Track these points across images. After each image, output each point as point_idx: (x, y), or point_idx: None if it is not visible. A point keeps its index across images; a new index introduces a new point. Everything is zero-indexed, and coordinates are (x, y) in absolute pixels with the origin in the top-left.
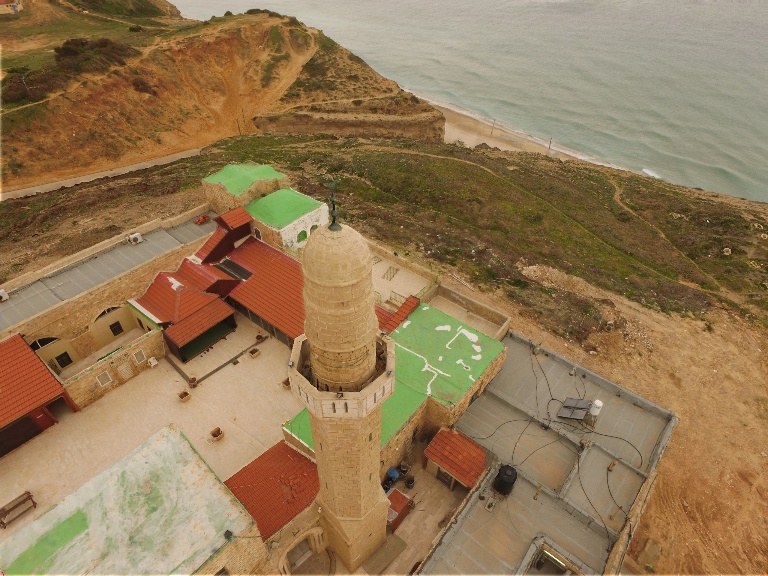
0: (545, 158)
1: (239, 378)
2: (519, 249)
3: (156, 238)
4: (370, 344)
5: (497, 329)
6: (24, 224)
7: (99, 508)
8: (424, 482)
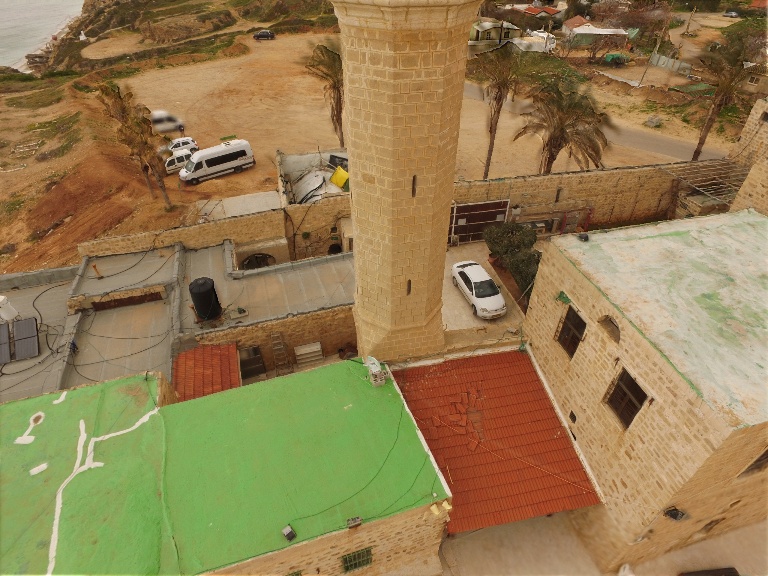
0: None
1: None
2: None
3: None
4: None
5: None
6: None
7: None
8: None
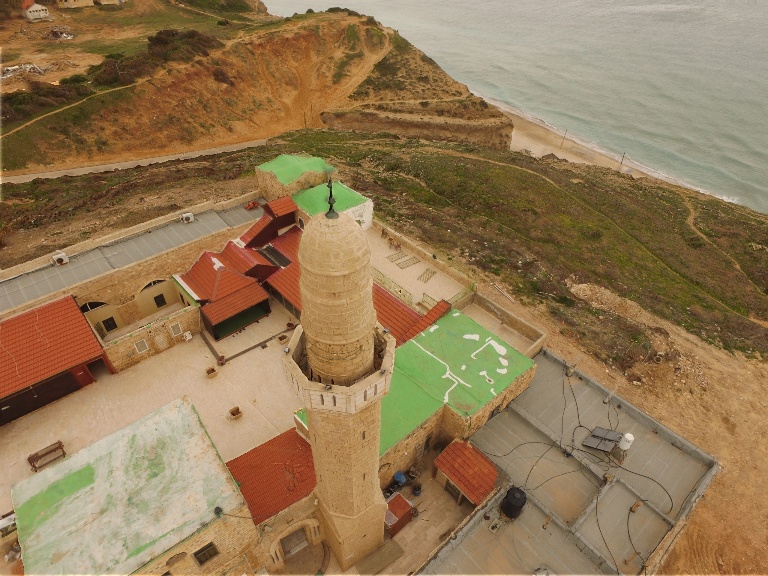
0: (615, 173)
1: (265, 362)
2: (571, 265)
3: (207, 219)
4: (364, 339)
5: (530, 345)
6: (99, 196)
7: (107, 466)
8: (431, 492)
